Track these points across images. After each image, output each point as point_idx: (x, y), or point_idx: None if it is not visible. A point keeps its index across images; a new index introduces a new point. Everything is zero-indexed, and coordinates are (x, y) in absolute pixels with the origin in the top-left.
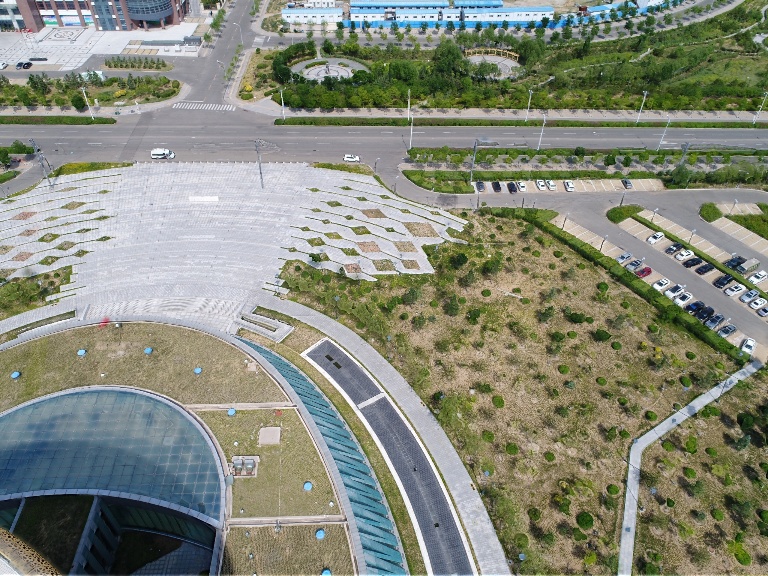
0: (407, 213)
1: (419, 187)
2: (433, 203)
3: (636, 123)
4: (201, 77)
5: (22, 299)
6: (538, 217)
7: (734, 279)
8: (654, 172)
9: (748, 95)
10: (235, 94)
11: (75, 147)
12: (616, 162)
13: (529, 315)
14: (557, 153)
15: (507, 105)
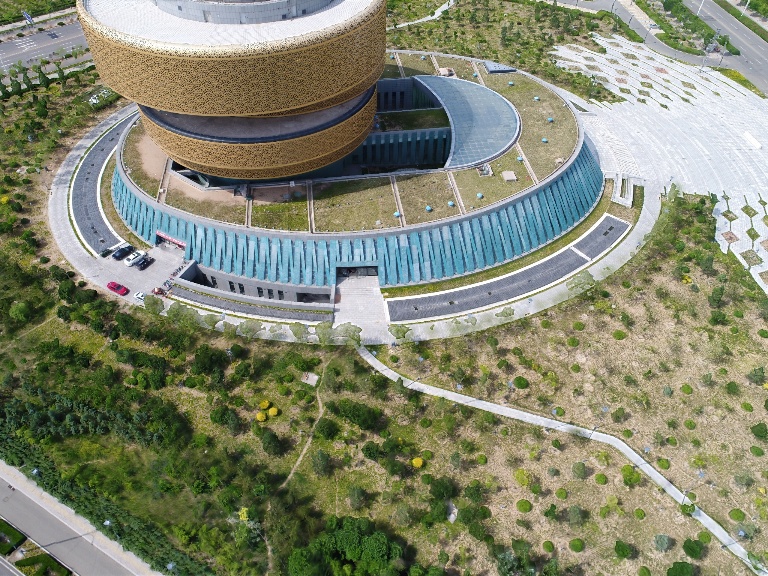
0: None
1: None
2: None
3: None
4: None
5: (585, 91)
6: None
7: None
8: None
9: None
10: None
11: (760, 68)
12: None
13: (753, 369)
14: None
15: None
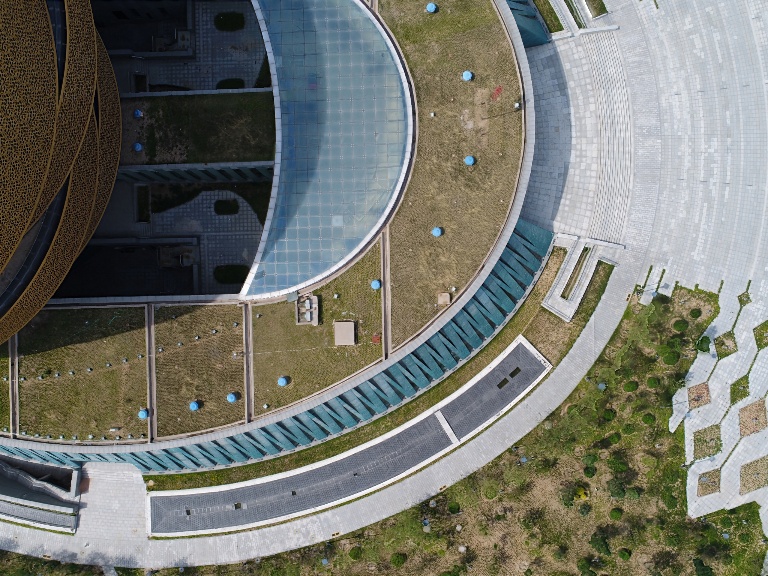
0: None
1: None
2: None
3: None
4: None
5: None
6: None
7: None
8: None
9: None
10: None
11: None
12: None
13: None
14: None
15: None
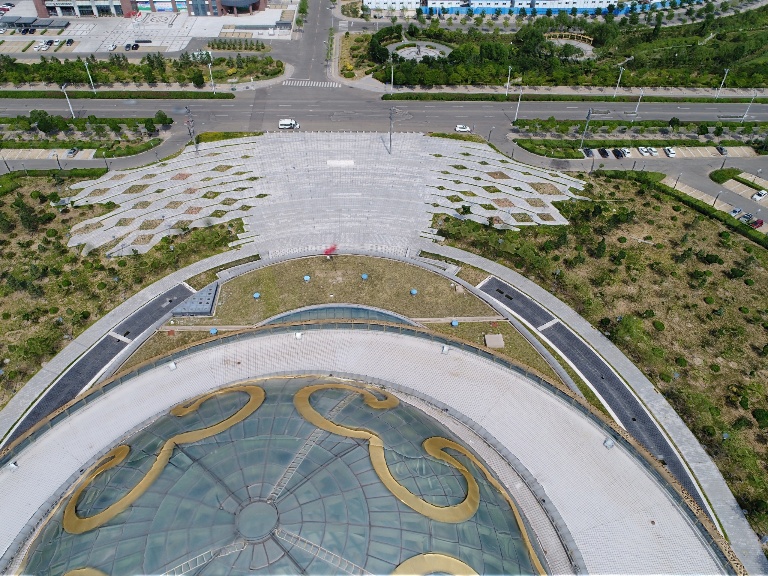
0: (529, 175)
1: (532, 153)
2: (549, 167)
3: (716, 99)
4: (300, 58)
5: (207, 245)
6: (649, 178)
7: None
8: (742, 141)
9: None
10: (337, 73)
11: (205, 119)
12: None
13: (666, 258)
14: None
15: (596, 82)
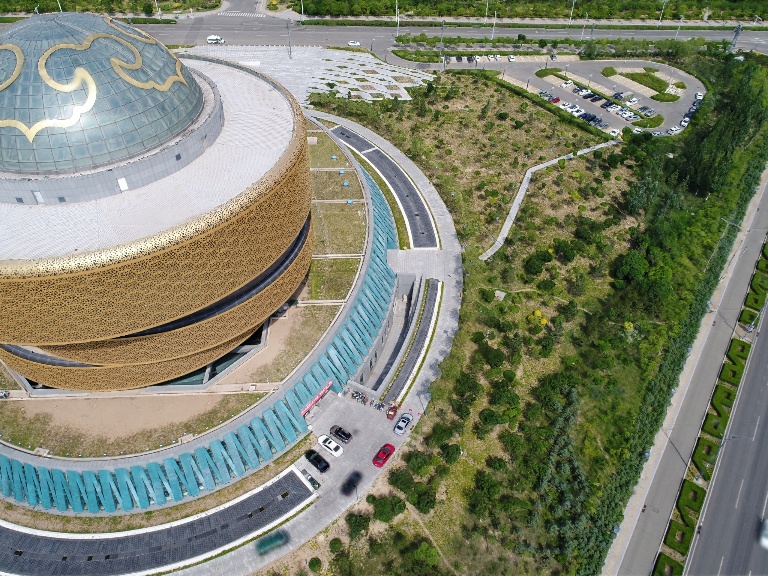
0: (394, 72)
1: (403, 59)
2: (413, 68)
3: (568, 25)
4: None
5: None
6: (486, 74)
7: (615, 103)
8: (575, 53)
9: (657, 8)
10: (264, 7)
11: None
12: (549, 48)
13: (473, 117)
14: (506, 42)
15: (471, 12)
